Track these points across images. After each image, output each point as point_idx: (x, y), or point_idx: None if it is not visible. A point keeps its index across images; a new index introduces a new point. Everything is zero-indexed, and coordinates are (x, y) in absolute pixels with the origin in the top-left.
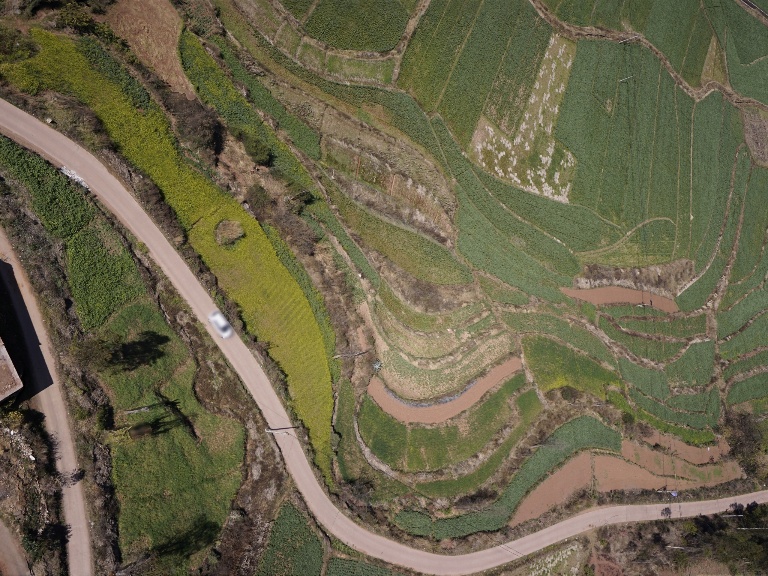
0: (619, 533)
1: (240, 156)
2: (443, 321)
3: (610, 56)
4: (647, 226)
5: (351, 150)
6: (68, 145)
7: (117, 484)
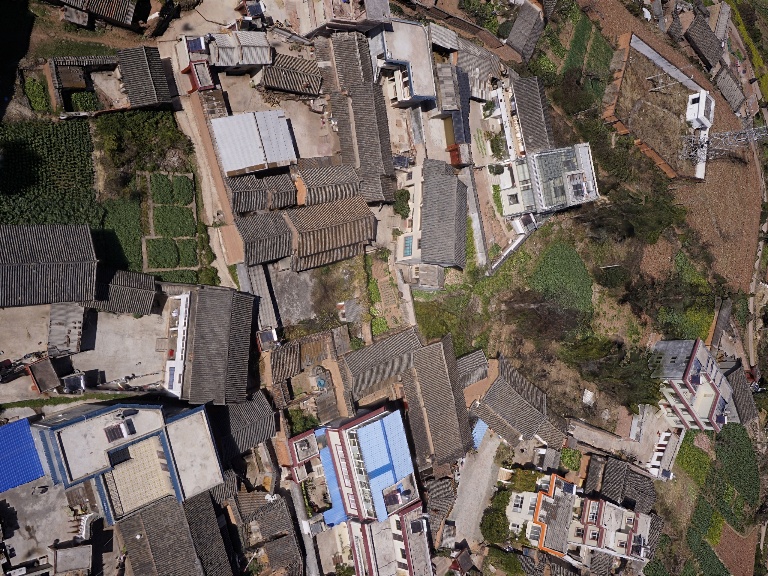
0: None
1: None
2: None
3: None
4: None
5: None
6: (731, 23)
7: None
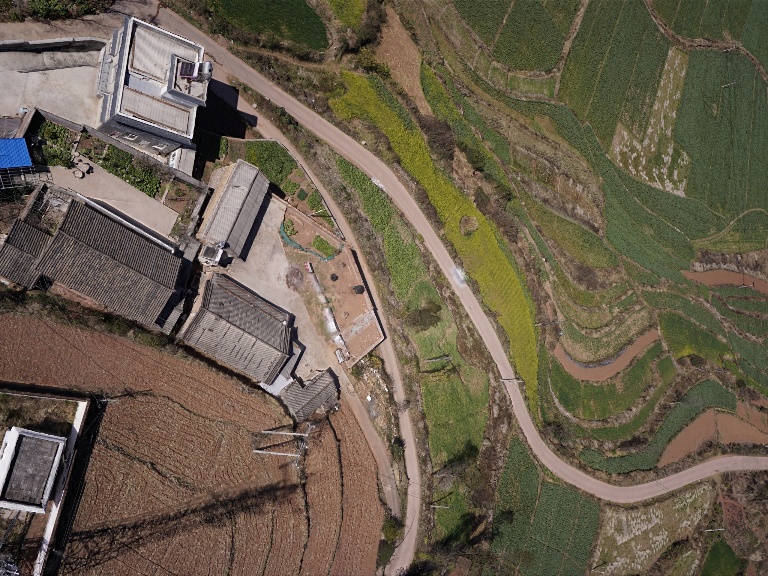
0: (738, 478)
1: (464, 164)
2: (599, 298)
3: (715, 64)
4: (746, 216)
5: (530, 155)
6: (374, 161)
7: (426, 413)
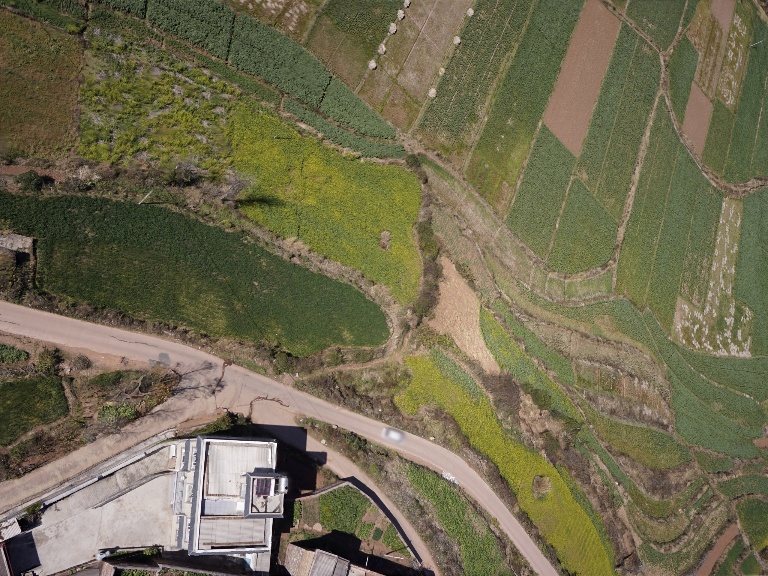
0: None
1: (530, 407)
2: (675, 503)
3: None
4: None
5: (593, 366)
6: (444, 453)
7: None
